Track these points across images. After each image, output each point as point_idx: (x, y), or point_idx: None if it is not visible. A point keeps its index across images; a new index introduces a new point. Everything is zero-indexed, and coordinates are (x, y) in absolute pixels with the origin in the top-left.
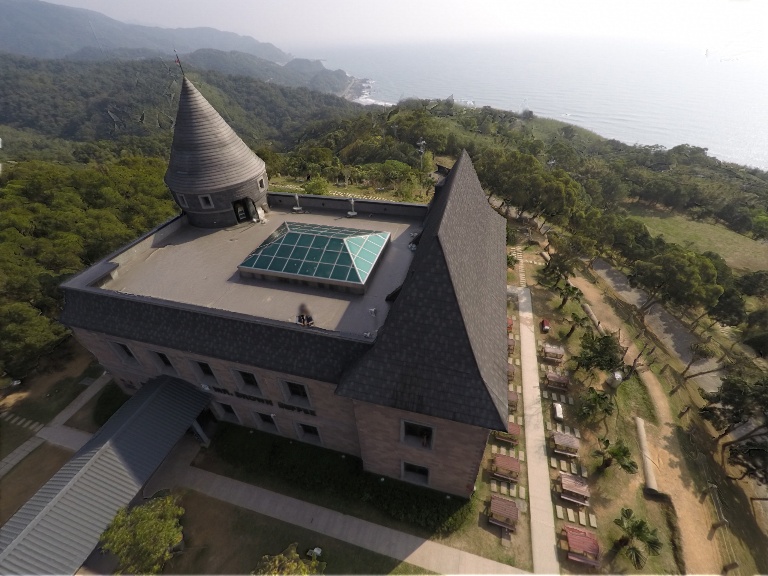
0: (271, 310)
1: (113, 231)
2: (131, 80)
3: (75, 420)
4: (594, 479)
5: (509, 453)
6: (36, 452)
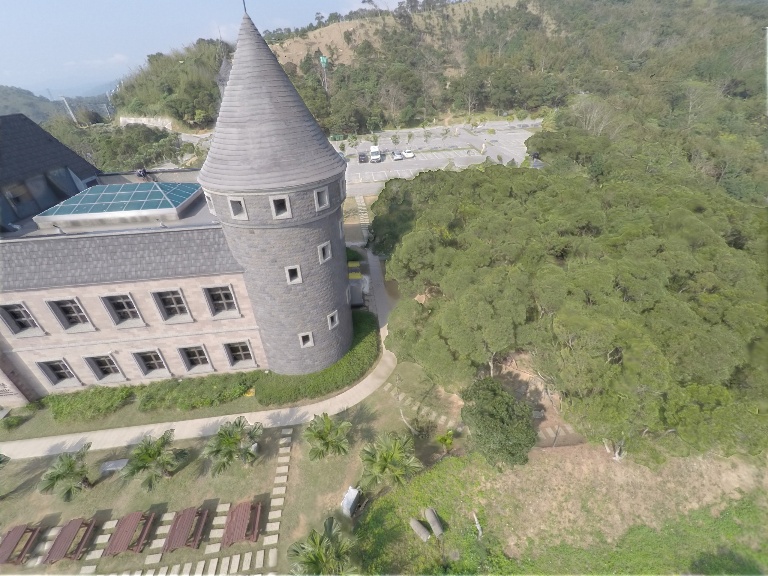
0: None
1: (432, 215)
2: None
3: (361, 248)
4: None
5: None
6: (362, 239)
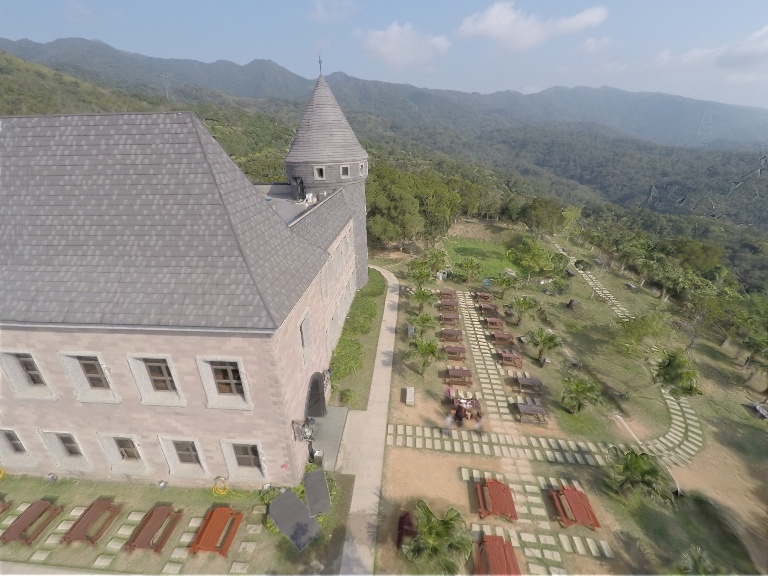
0: None
1: None
2: (706, 164)
3: None
4: None
5: None
6: None
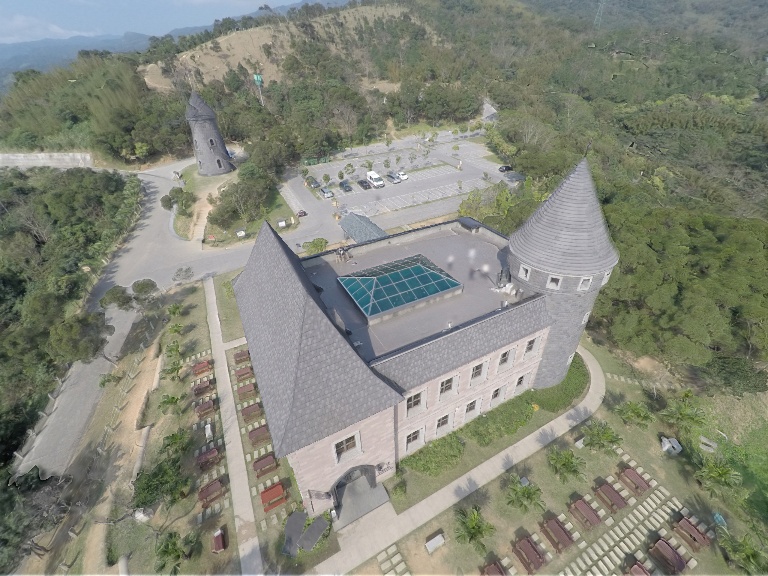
0: (374, 259)
1: None
2: None
3: None
4: (187, 406)
5: (244, 384)
6: None
